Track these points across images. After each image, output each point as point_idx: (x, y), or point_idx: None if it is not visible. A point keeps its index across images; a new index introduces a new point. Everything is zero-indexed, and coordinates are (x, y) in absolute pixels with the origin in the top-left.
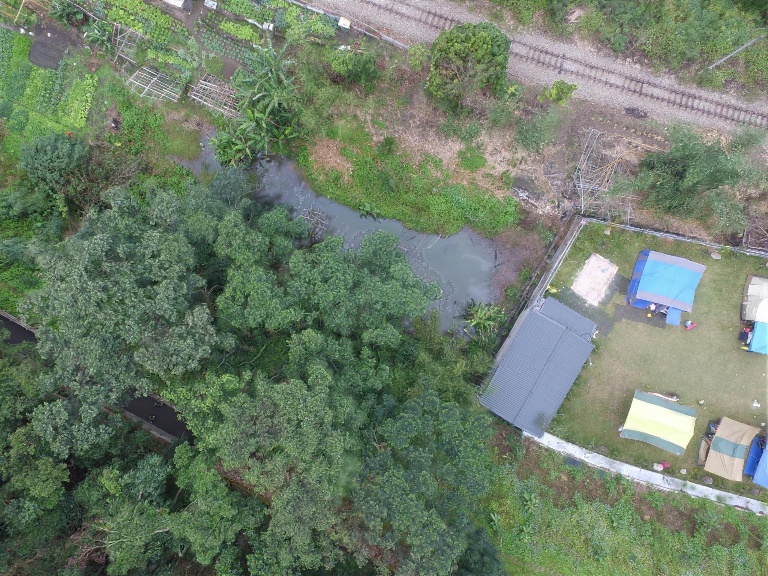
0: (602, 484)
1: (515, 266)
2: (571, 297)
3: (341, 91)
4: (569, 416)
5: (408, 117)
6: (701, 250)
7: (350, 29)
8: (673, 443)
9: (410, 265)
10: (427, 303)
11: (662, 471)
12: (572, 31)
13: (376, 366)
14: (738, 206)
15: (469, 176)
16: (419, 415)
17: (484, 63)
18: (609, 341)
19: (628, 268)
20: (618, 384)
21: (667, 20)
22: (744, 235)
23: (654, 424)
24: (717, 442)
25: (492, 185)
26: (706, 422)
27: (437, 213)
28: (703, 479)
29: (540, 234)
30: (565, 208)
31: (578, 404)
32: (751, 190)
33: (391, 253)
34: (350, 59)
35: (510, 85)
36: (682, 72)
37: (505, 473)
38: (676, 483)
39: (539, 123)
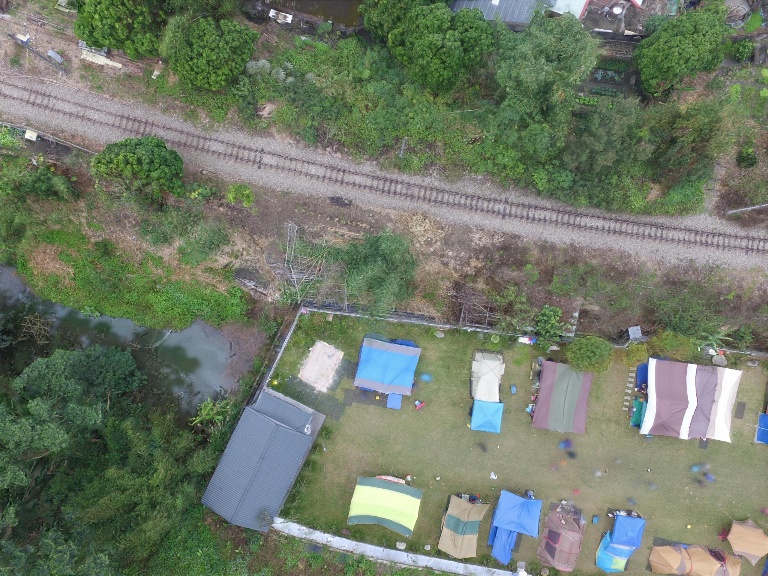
0: (342, 568)
1: (247, 356)
2: (299, 385)
3: (21, 209)
4: (308, 502)
5: (122, 218)
6: (424, 329)
7: (41, 139)
8: (403, 525)
9: (144, 362)
10: (65, 437)
11: (406, 549)
12: (266, 126)
13: (1, 510)
14: (459, 283)
15: (189, 272)
16: (19, 567)
17: (143, 178)
18: (341, 426)
19: (354, 352)
20: (354, 467)
21: (354, 111)
22: (461, 313)
23: (382, 508)
24: (448, 520)
25: (213, 279)
26: (445, 497)
27: (161, 310)
28: (447, 554)
29: (260, 326)
30: (292, 295)
31: (316, 490)
32: (466, 268)
33: (61, 376)
34: (7, 184)
35: (193, 190)
36: (383, 158)
37: (232, 570)
38: (420, 560)
39: (245, 218)
